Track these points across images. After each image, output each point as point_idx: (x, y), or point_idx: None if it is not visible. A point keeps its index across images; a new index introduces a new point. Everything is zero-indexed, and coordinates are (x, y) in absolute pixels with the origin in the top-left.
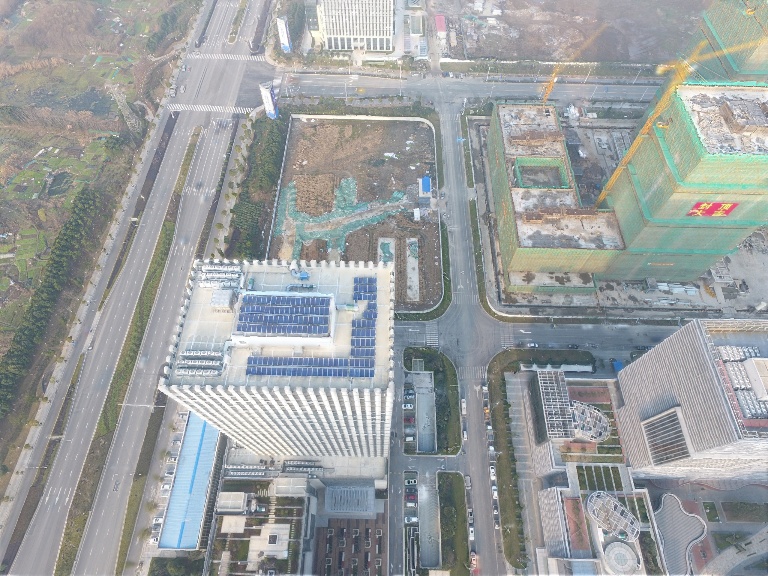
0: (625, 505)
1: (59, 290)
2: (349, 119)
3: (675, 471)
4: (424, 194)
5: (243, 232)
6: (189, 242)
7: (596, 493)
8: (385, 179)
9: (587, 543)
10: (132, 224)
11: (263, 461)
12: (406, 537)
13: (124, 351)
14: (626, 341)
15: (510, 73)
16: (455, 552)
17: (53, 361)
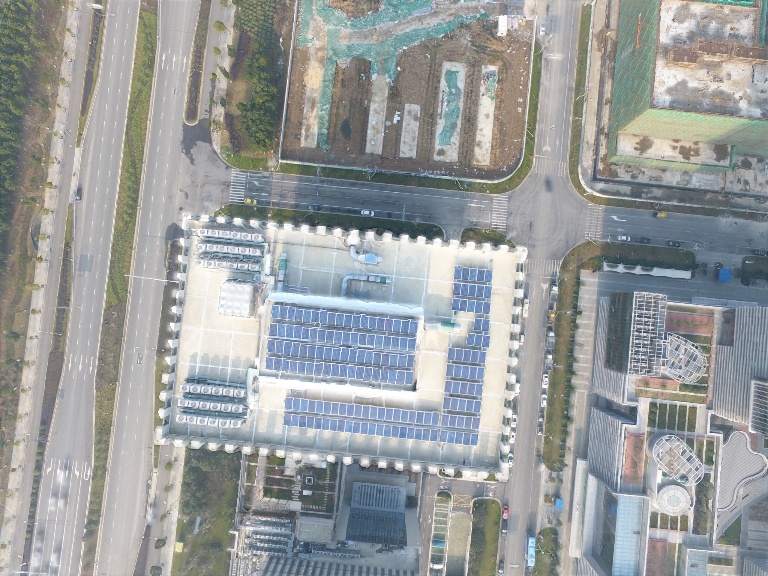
0: (692, 446)
1: (19, 115)
2: None
3: None
4: None
5: (253, 38)
6: (180, 49)
7: (667, 437)
8: None
9: (640, 479)
10: (96, 13)
11: None
12: None
13: (120, 205)
14: (743, 242)
15: None
16: None
17: (37, 211)
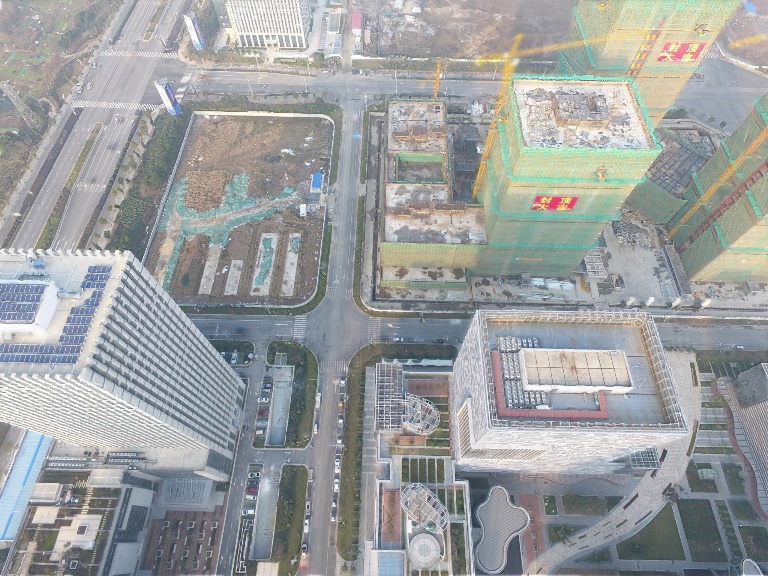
0: (443, 497)
1: None
2: (252, 116)
3: (498, 463)
4: (314, 190)
5: (127, 227)
6: (72, 237)
7: (412, 485)
8: (278, 175)
9: (398, 535)
10: (16, 219)
11: (87, 453)
12: (241, 529)
13: None
14: None
15: (420, 70)
16: (287, 544)
17: None
